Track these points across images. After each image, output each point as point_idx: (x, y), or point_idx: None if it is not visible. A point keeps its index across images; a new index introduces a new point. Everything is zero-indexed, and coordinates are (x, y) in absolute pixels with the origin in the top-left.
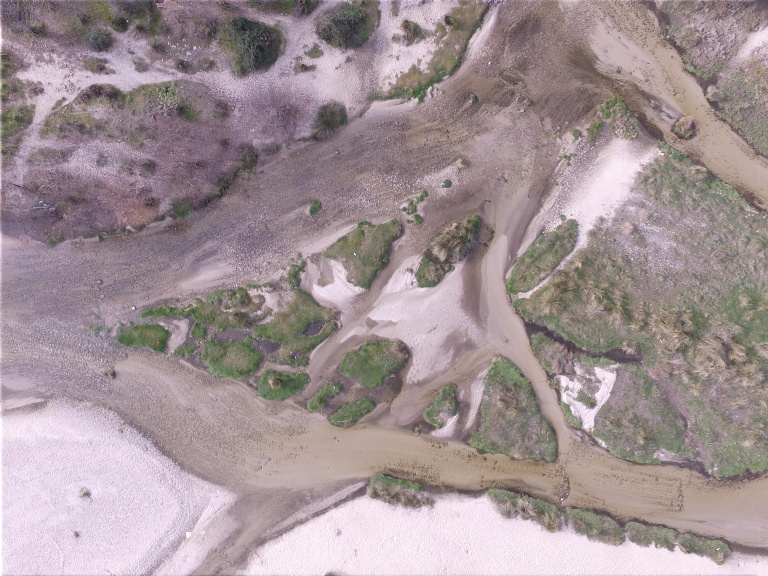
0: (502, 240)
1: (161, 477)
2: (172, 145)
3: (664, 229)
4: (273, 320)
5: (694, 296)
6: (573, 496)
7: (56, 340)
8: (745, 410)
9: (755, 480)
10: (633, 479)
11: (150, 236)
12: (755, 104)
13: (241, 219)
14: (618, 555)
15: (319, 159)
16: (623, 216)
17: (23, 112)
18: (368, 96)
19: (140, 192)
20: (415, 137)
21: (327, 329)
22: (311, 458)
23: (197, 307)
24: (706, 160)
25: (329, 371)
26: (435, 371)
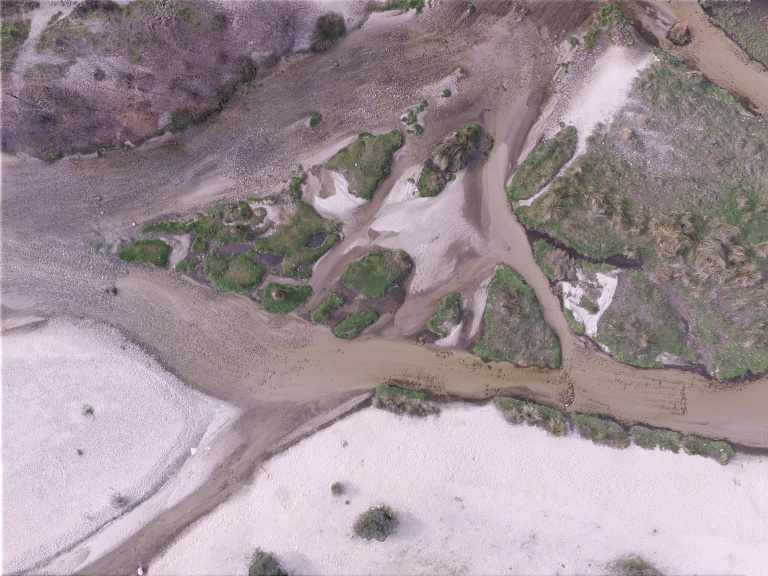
0: (502, 148)
1: (165, 392)
2: (170, 58)
3: (662, 134)
4: (275, 233)
5: (693, 199)
6: (578, 402)
7: (56, 258)
8: (745, 311)
9: (756, 381)
10: (636, 383)
11: (149, 151)
12: (748, 9)
13: (241, 133)
14: (623, 458)
15: (318, 71)
16: (621, 121)
17: (19, 27)
18: (366, 7)
19: (139, 107)
20: (414, 48)
21: (329, 240)
22: (316, 371)
23: (198, 221)
24: (701, 66)
25: (332, 283)
26: (438, 280)
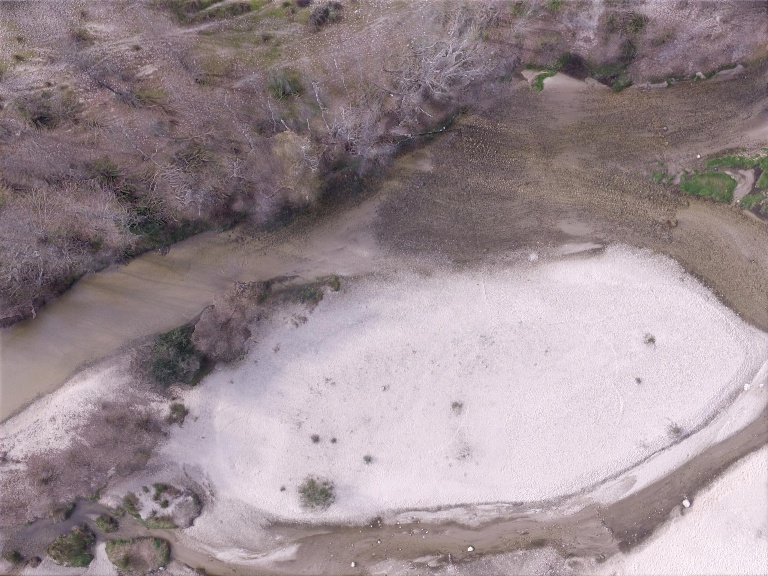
0: None
1: (726, 326)
2: None
3: None
4: None
5: None
6: None
7: (617, 186)
8: None
9: None
10: None
11: (718, 84)
12: None
13: None
14: None
15: None
16: None
17: None
18: None
19: (715, 38)
20: None
21: None
22: None
23: (767, 156)
24: None
25: None
26: None
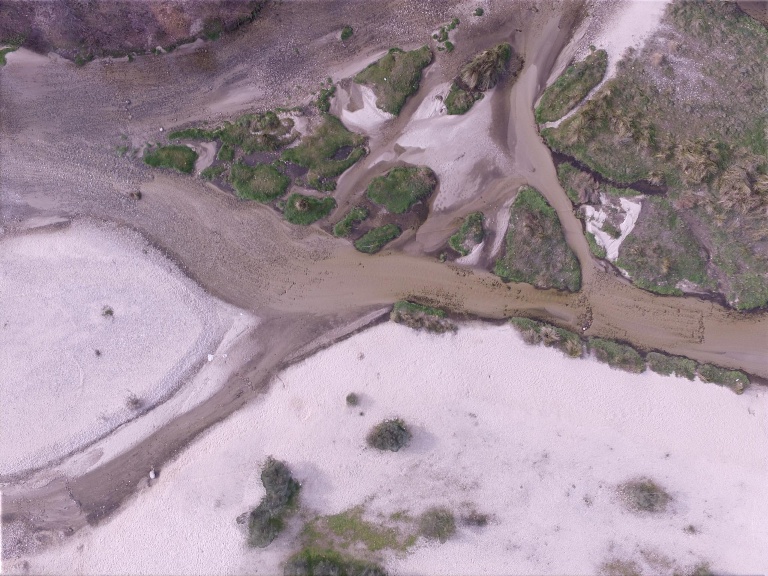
0: (532, 70)
1: (185, 297)
2: None
3: (692, 61)
4: (301, 144)
5: (720, 128)
6: (595, 326)
7: (82, 160)
8: (767, 242)
9: None
10: (655, 310)
11: (180, 58)
12: None
13: (272, 43)
14: (639, 383)
15: None
16: (652, 47)
17: None
18: None
19: (171, 12)
20: None
21: (355, 154)
22: (335, 283)
23: (225, 129)
24: None
25: (356, 196)
26: (462, 199)
